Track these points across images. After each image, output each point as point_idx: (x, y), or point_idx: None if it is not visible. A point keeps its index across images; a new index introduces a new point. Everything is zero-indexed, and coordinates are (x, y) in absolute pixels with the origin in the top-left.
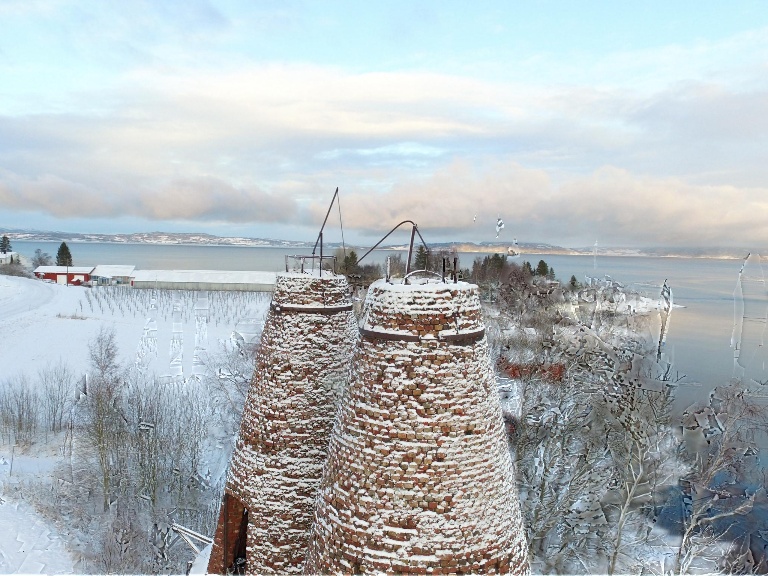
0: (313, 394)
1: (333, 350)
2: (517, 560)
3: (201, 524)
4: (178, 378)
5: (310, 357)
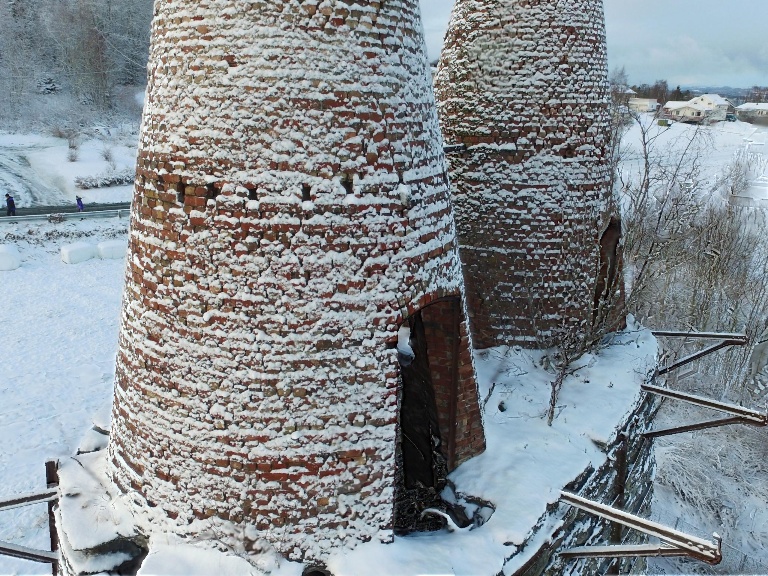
0: (455, 65)
1: (493, 1)
2: (232, 206)
3: (720, 370)
4: (763, 203)
5: (464, 13)
